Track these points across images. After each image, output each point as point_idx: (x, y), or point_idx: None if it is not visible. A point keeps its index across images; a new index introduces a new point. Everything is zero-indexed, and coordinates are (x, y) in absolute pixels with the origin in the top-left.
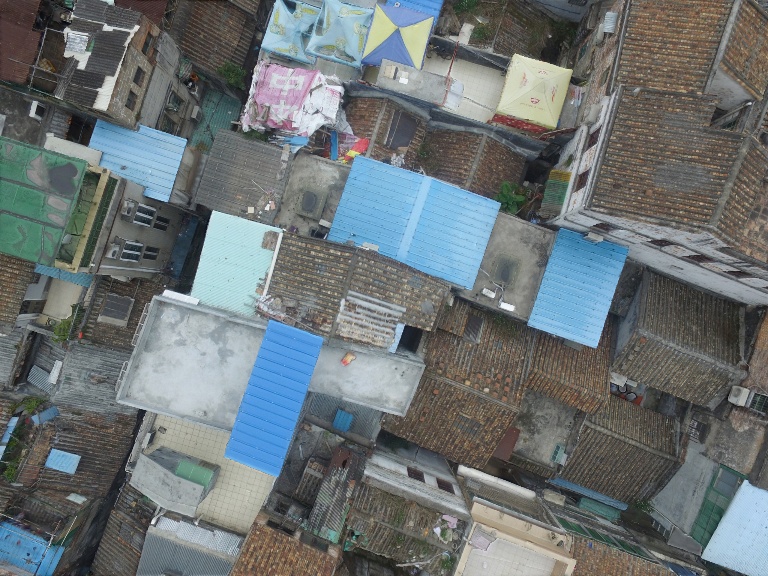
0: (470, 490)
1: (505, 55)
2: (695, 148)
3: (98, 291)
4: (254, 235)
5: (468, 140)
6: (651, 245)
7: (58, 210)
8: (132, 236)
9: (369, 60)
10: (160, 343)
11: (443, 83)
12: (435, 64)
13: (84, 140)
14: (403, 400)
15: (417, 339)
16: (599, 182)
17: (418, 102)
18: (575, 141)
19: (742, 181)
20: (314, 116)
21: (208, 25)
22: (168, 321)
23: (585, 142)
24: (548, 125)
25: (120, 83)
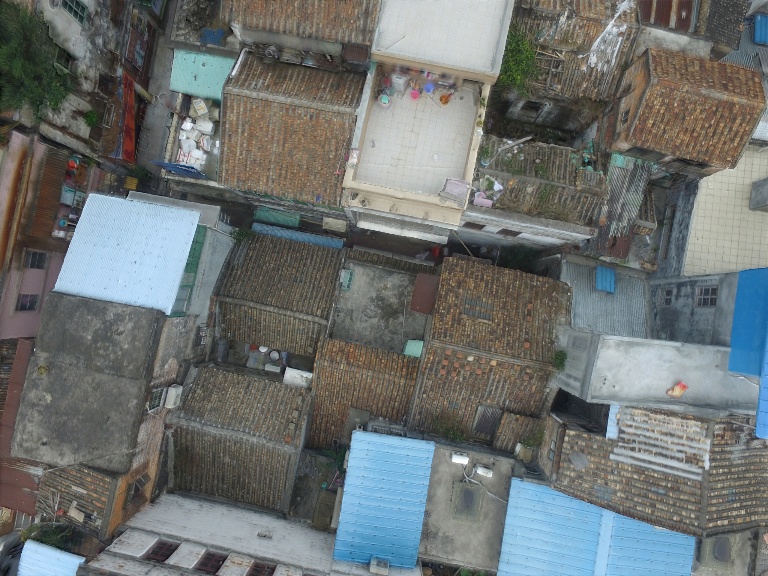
0: None
1: None
2: None
3: None
4: None
5: None
6: (314, 573)
7: None
8: None
9: None
10: None
11: None
12: None
13: None
14: None
15: None
16: None
17: None
18: None
19: None
20: None
21: None
22: None
23: None
24: None
25: None
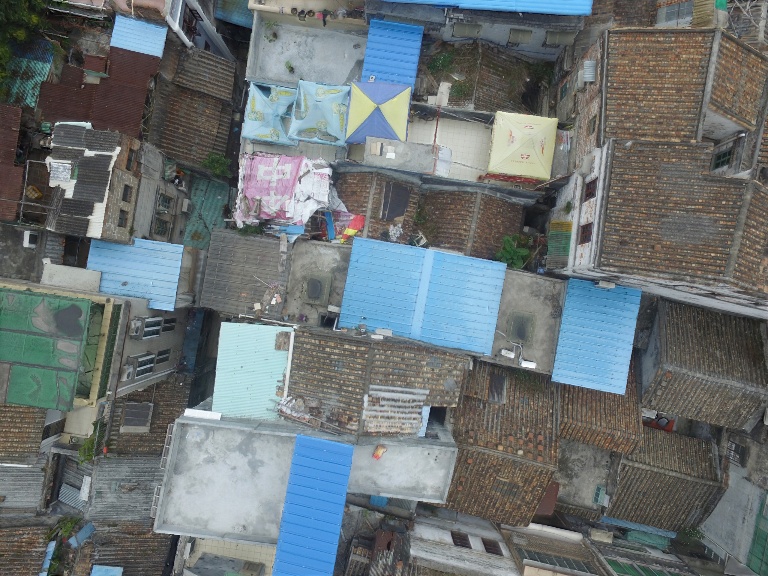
0: (517, 546)
1: (487, 108)
2: (697, 198)
3: (116, 402)
4: (266, 339)
5: (463, 199)
6: None
7: (68, 353)
8: (143, 349)
9: (353, 139)
10: (189, 464)
11: (430, 152)
12: (418, 127)
13: (80, 254)
14: (440, 485)
15: (443, 409)
16: (605, 240)
17: (408, 172)
18: (571, 188)
19: (750, 226)
20: (306, 203)
21: (185, 119)
22: (193, 440)
23: (582, 192)
24: (542, 177)
25: (110, 207)
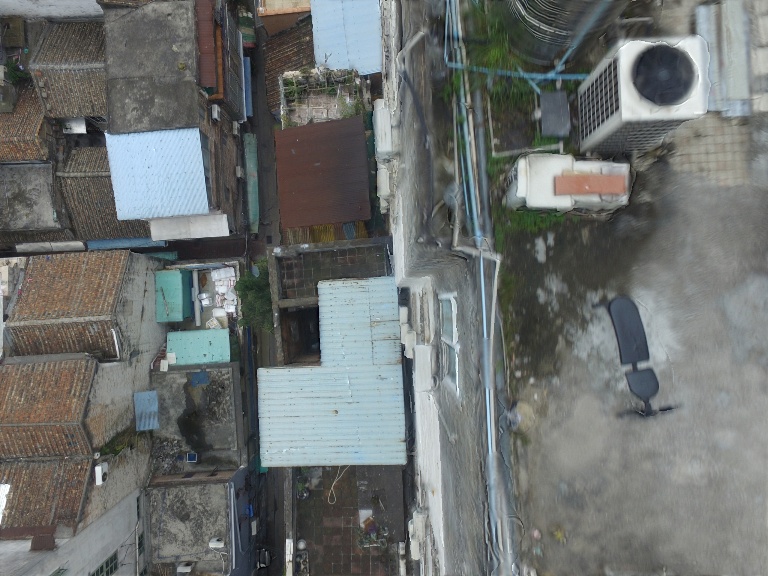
0: None
1: None
2: None
3: None
4: None
5: None
6: None
7: None
8: None
9: None
10: None
11: None
12: None
13: None
14: None
15: None
16: None
17: None
18: None
19: None
20: None
21: None
22: None
23: None
24: None
25: None
